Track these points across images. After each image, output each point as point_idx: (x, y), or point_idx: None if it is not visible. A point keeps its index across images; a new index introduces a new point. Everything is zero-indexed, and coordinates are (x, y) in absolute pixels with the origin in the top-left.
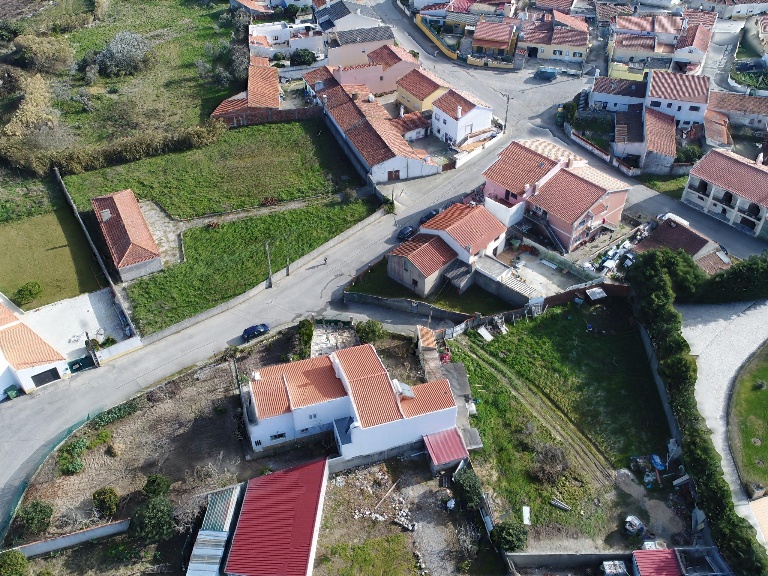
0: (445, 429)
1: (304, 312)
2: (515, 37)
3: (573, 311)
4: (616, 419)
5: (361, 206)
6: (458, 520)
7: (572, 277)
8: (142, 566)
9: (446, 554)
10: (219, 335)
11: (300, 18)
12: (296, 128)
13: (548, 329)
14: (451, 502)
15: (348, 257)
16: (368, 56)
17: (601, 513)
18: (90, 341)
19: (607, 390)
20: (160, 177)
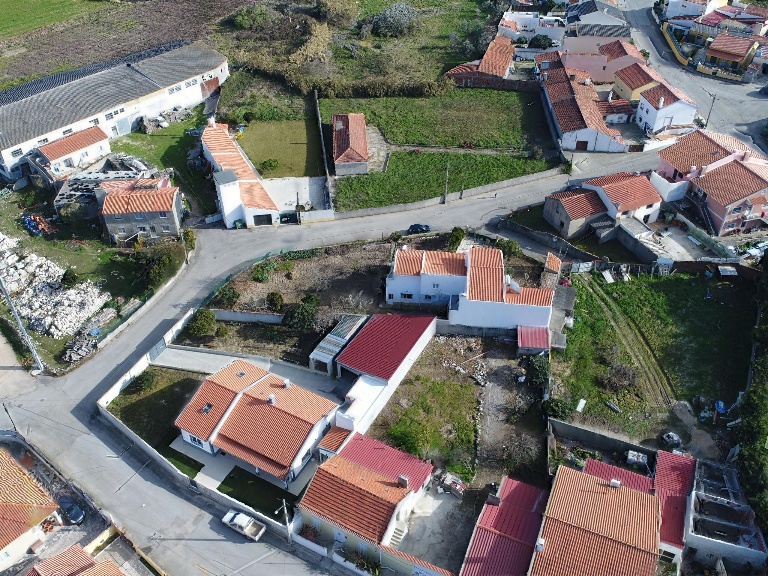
0: (538, 326)
1: (463, 226)
2: (754, 53)
3: (700, 281)
4: (697, 366)
5: (543, 163)
6: (522, 390)
7: (711, 254)
8: (285, 347)
9: (503, 408)
10: (392, 225)
11: (555, 13)
12: (513, 96)
13: (668, 288)
14: (522, 377)
15: (515, 197)
16: (599, 48)
17: (647, 423)
18: (299, 205)
19: (700, 344)
20: (390, 112)
